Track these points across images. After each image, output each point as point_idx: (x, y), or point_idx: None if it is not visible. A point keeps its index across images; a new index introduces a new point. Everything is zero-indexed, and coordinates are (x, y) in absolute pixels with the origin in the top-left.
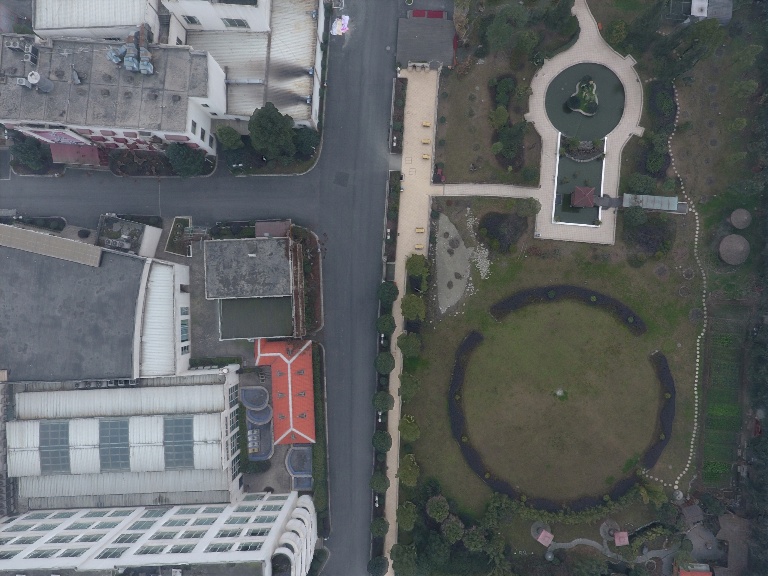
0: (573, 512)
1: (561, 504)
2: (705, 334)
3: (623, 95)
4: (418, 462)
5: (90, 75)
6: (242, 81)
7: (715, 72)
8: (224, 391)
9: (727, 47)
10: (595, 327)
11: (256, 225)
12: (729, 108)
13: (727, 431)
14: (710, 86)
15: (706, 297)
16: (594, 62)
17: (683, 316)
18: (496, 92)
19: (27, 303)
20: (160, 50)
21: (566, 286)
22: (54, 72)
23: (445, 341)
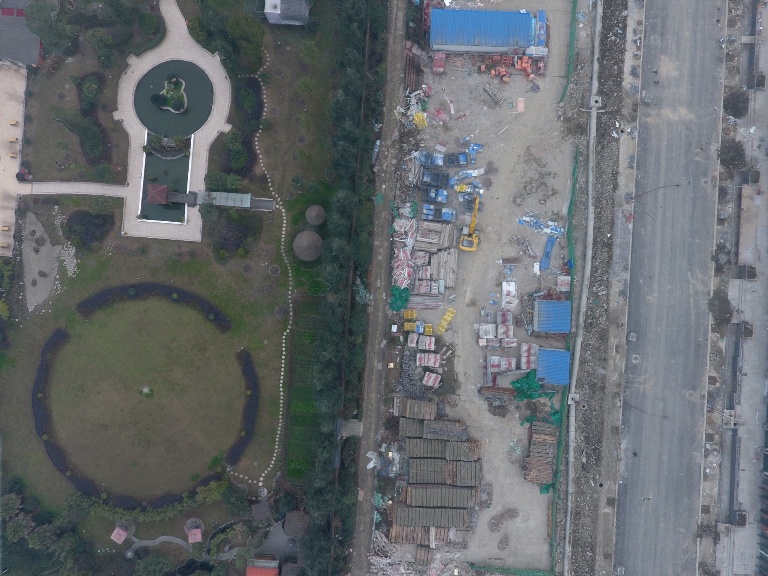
0: (150, 509)
1: (142, 501)
2: (290, 331)
3: (212, 92)
4: (2, 460)
5: None
6: None
7: (303, 69)
8: None
9: (316, 44)
10: (182, 324)
11: None
12: (317, 105)
13: (312, 427)
14: None
15: (292, 294)
16: (183, 59)
17: (269, 313)
18: (81, 90)
19: None
20: None
21: (149, 283)
22: None
23: (32, 339)
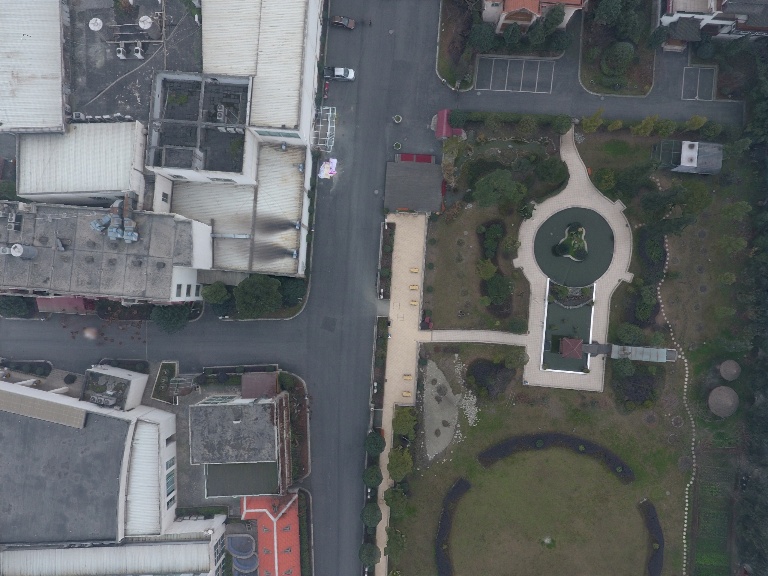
0: None
1: None
2: (694, 482)
3: (612, 240)
4: None
5: (74, 241)
6: (228, 236)
7: (705, 217)
8: (209, 551)
9: (717, 192)
10: (583, 475)
11: (242, 378)
12: (719, 254)
13: None
14: (700, 231)
15: (695, 445)
16: (583, 207)
17: (672, 464)
18: (484, 238)
19: (11, 463)
20: (145, 216)
21: (554, 435)
22: (38, 238)
23: (433, 488)
